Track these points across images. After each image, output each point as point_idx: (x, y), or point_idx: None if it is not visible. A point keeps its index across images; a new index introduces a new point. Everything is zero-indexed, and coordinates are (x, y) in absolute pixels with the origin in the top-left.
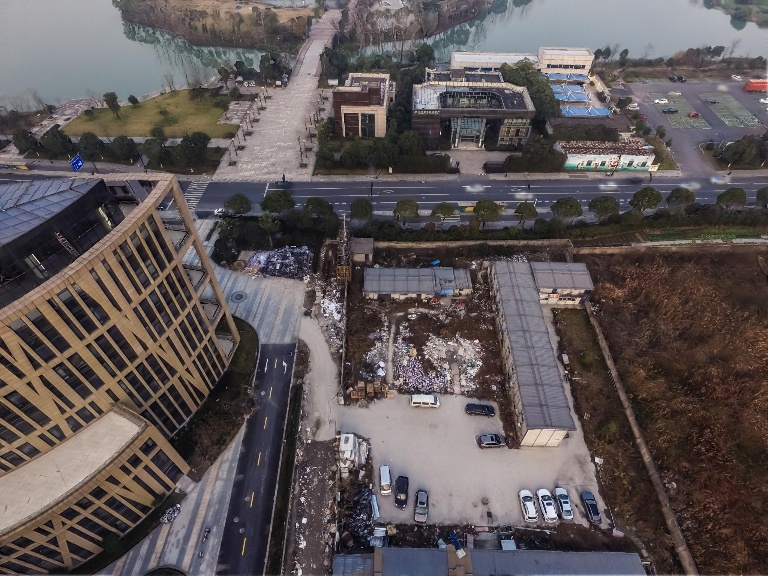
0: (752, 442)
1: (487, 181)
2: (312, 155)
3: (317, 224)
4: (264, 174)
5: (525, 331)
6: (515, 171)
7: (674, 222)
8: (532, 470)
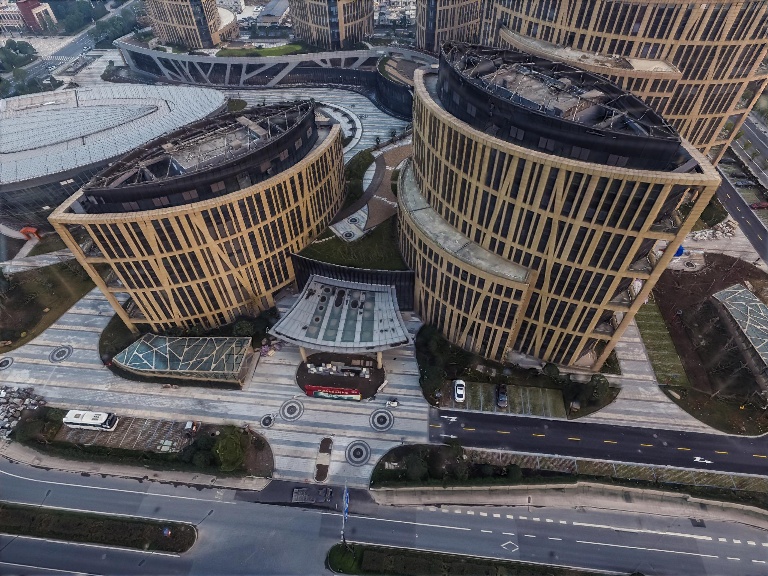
0: None
1: None
2: None
3: None
4: (58, 45)
5: None
6: (122, 3)
7: None
8: (249, 10)
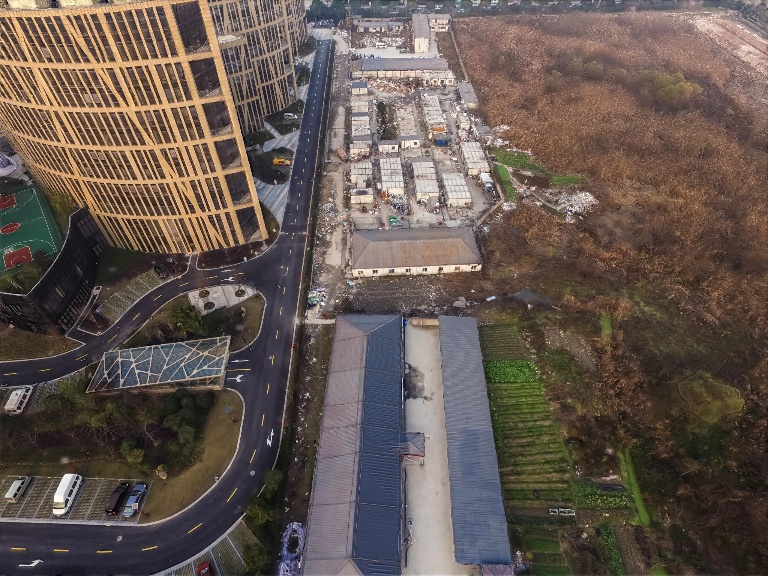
0: (496, 49)
1: (418, 7)
2: (330, 2)
3: (336, 13)
4: (307, 7)
5: None
6: None
7: (498, 11)
8: None
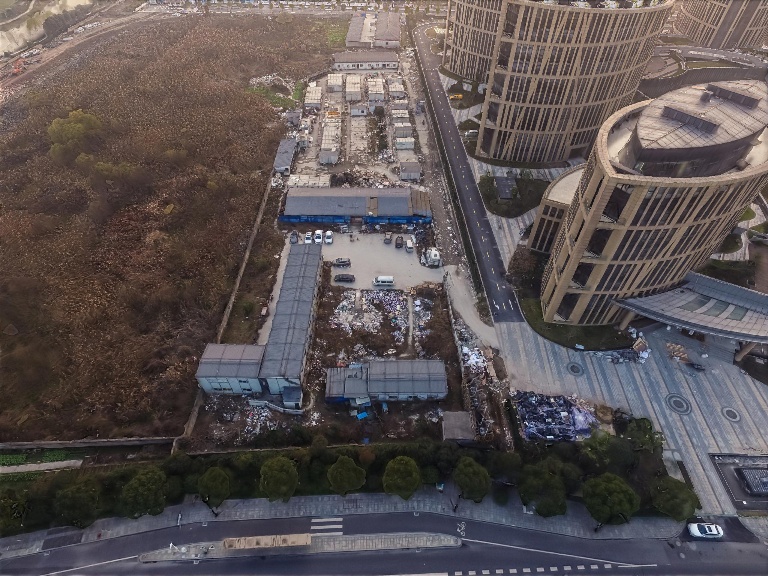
0: (172, 261)
1: None
2: None
3: None
4: None
5: (298, 300)
6: None
7: None
8: None
